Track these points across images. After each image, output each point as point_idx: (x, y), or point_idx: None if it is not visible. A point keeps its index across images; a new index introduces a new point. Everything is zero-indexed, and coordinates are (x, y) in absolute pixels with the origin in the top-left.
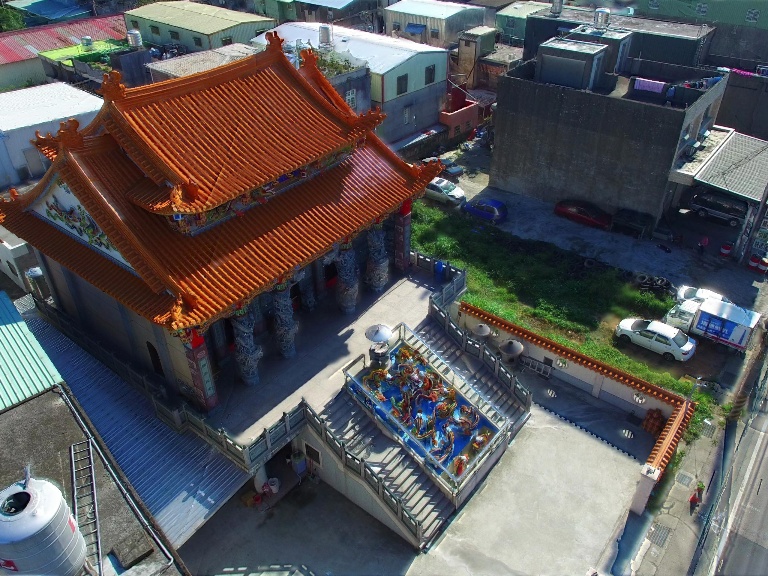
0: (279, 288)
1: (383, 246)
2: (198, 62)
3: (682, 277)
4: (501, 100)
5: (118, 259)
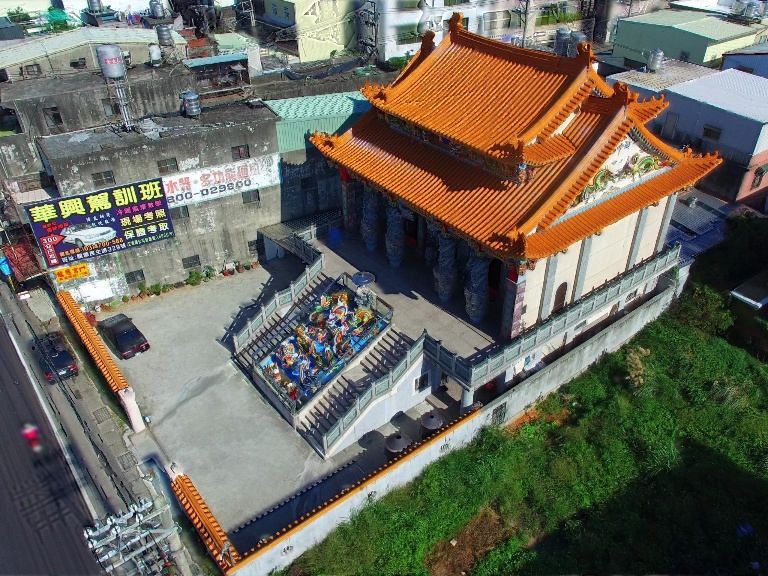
0: None
1: (478, 278)
2: None
3: None
4: None
5: None
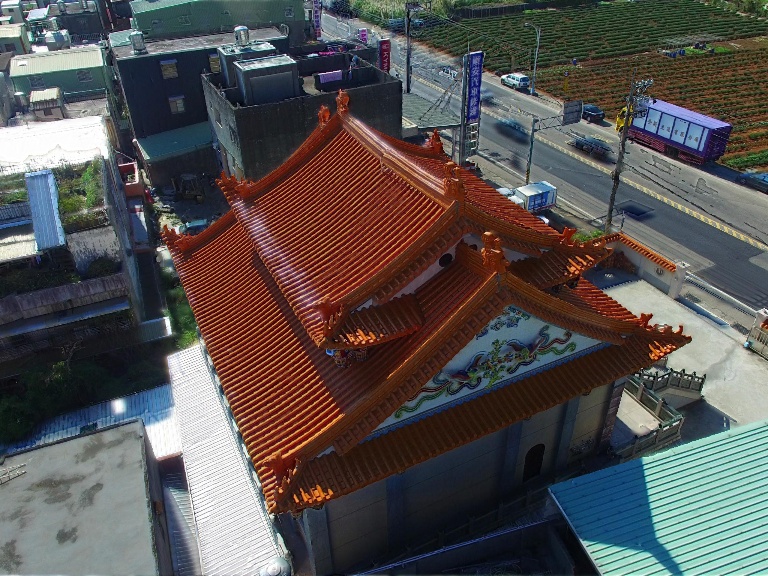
0: None
1: None
2: None
3: None
4: (245, 133)
5: (543, 364)
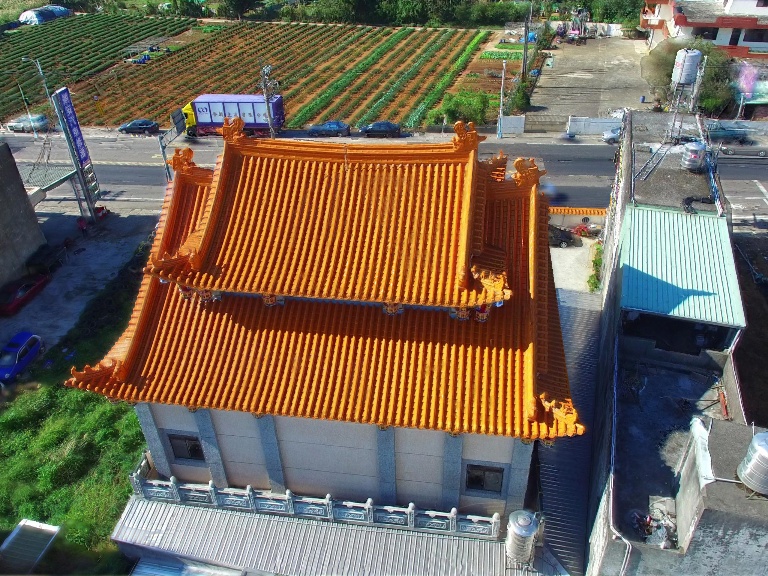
0: None
1: None
2: None
3: (126, 241)
4: None
5: None
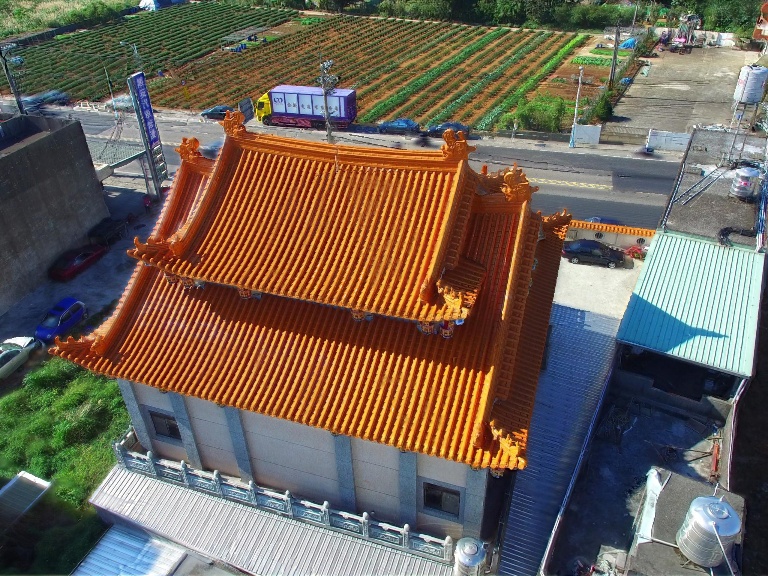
0: None
1: None
2: None
3: None
4: None
5: None
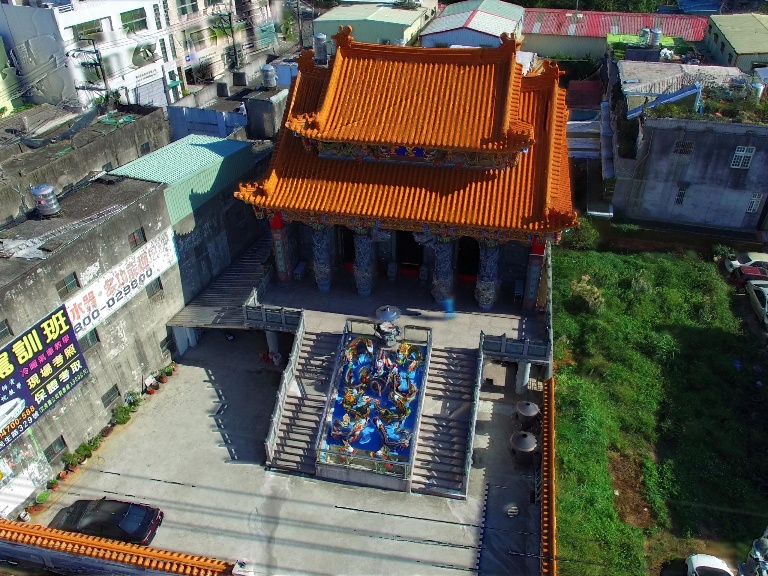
0: (356, 231)
1: (493, 266)
2: (653, 70)
3: None
4: None
5: None
